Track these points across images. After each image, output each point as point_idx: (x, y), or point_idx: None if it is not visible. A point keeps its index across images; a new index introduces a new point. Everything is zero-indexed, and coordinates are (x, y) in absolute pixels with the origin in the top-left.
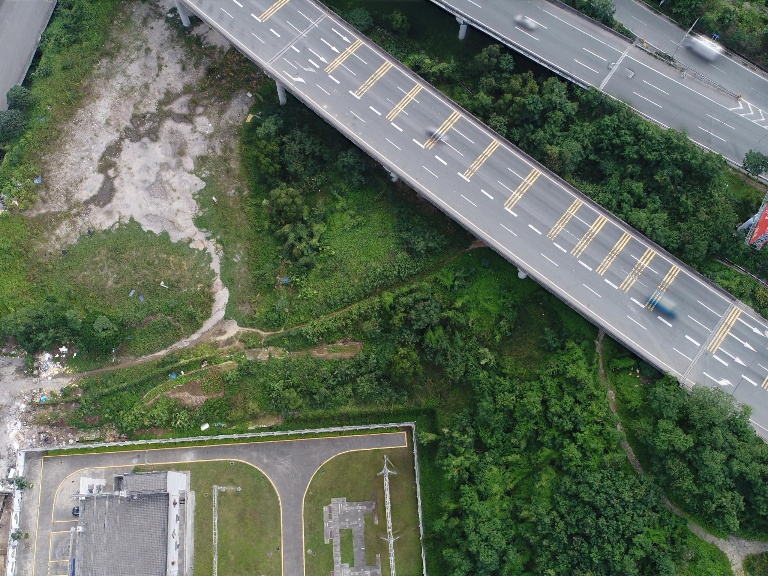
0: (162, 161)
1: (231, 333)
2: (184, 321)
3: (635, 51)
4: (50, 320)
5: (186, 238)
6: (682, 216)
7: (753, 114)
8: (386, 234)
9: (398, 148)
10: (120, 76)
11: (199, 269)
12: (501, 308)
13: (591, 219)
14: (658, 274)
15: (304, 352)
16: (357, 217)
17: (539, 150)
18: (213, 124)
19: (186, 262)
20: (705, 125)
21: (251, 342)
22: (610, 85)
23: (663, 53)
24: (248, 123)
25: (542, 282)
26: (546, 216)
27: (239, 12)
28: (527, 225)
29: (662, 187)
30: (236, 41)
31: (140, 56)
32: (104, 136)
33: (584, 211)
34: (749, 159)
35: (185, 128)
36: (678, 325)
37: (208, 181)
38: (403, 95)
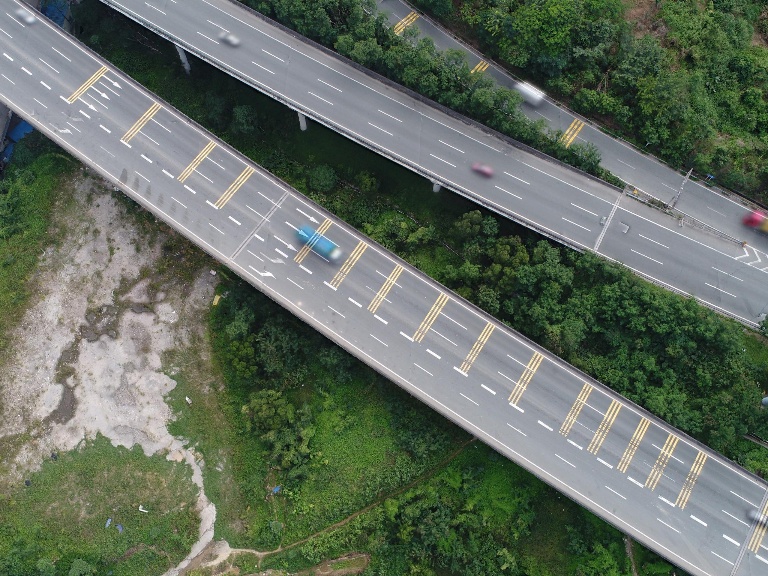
0: (125, 361)
1: (223, 556)
2: (170, 549)
3: (626, 201)
4: (20, 569)
5: (161, 449)
6: (701, 390)
7: (761, 261)
8: (382, 433)
9: (385, 345)
10: (68, 266)
11: (180, 485)
12: (516, 507)
13: (604, 406)
14: (684, 464)
15: (306, 572)
16: (348, 418)
17: (537, 326)
18: (177, 311)
19: (164, 478)
20: (712, 280)
21: (247, 568)
22: (605, 244)
23: (657, 201)
24: (215, 306)
25: (561, 490)
26: (555, 408)
27: (192, 200)
28: (536, 421)
29: (675, 358)
30: (193, 235)
31: (88, 240)
32: (58, 339)
33: (595, 397)
34: (767, 328)
35: (147, 319)
36: (713, 523)
37: (179, 379)
38: (383, 280)
